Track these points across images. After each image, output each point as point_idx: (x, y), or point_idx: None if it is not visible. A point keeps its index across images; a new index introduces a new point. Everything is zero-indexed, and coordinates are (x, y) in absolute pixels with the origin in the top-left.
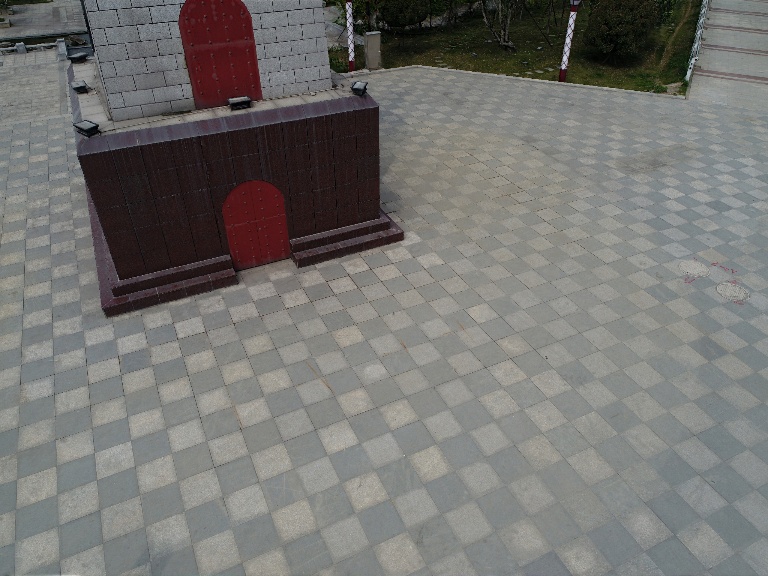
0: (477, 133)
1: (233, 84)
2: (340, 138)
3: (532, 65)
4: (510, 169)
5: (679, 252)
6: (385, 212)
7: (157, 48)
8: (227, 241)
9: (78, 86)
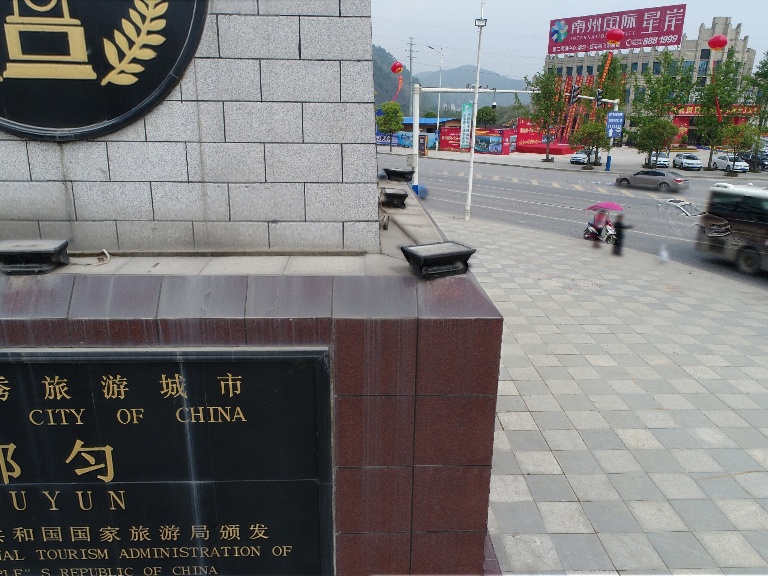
0: None
1: None
2: None
3: None
4: None
5: (528, 280)
6: None
7: None
8: None
9: (56, 244)
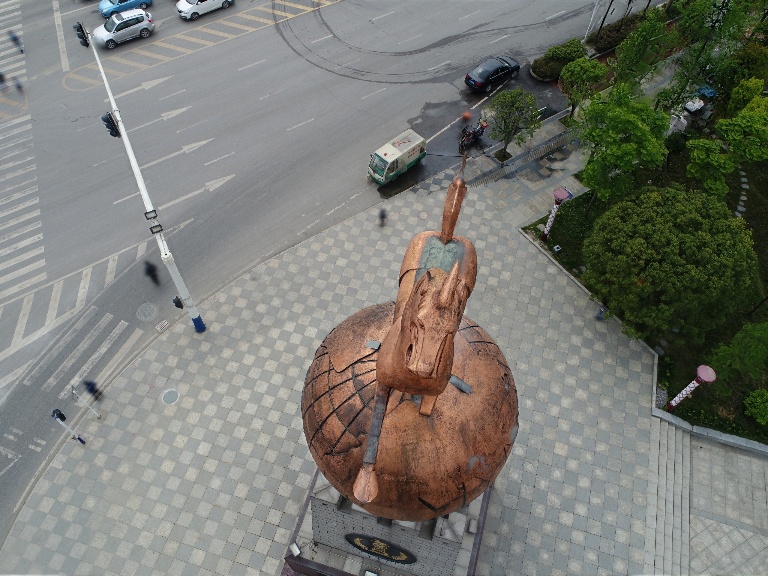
0: None
1: None
2: None
3: None
4: None
5: None
6: None
7: None
8: None
9: None
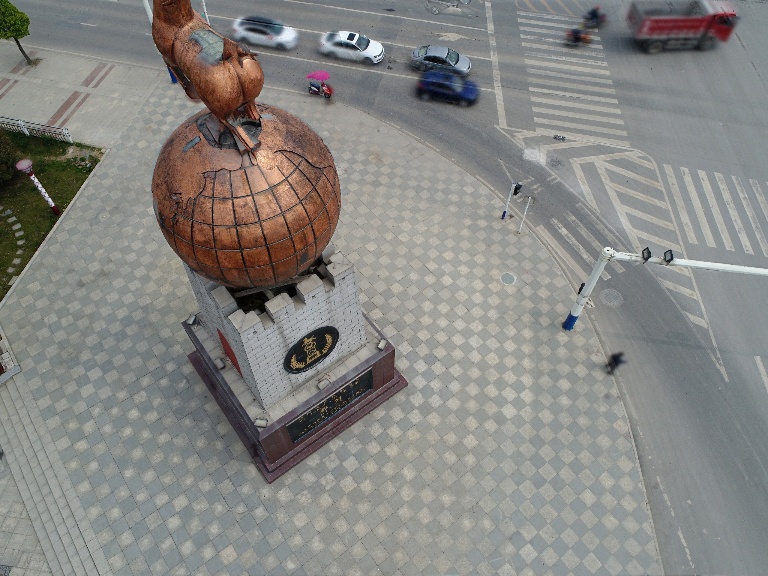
0: (171, 259)
1: None
2: None
3: (1, 230)
4: None
5: None
6: None
7: None
8: None
9: (328, 381)
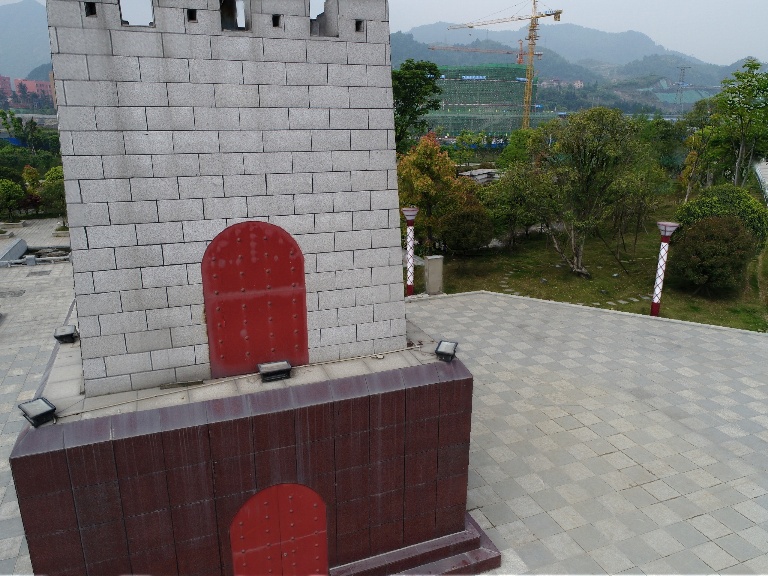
0: (570, 381)
1: (269, 344)
2: (416, 421)
3: (612, 294)
4: (629, 440)
5: None
6: (467, 508)
7: (166, 297)
8: (233, 575)
9: (62, 334)
